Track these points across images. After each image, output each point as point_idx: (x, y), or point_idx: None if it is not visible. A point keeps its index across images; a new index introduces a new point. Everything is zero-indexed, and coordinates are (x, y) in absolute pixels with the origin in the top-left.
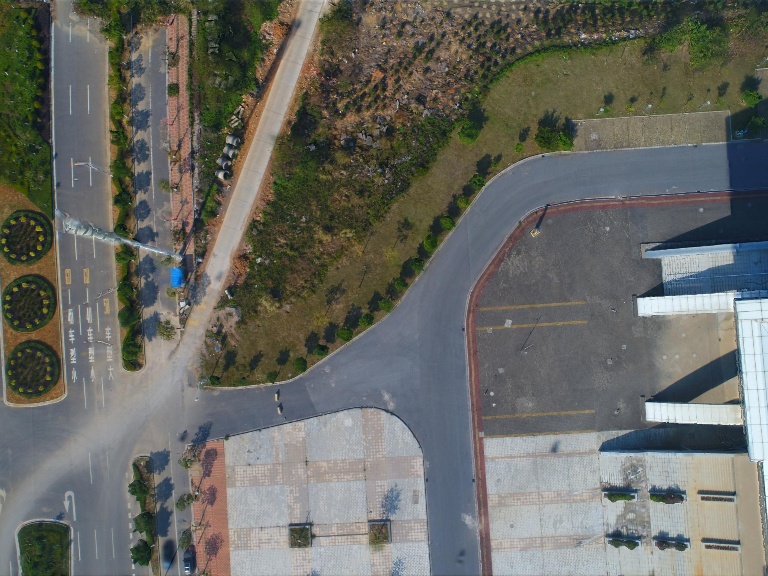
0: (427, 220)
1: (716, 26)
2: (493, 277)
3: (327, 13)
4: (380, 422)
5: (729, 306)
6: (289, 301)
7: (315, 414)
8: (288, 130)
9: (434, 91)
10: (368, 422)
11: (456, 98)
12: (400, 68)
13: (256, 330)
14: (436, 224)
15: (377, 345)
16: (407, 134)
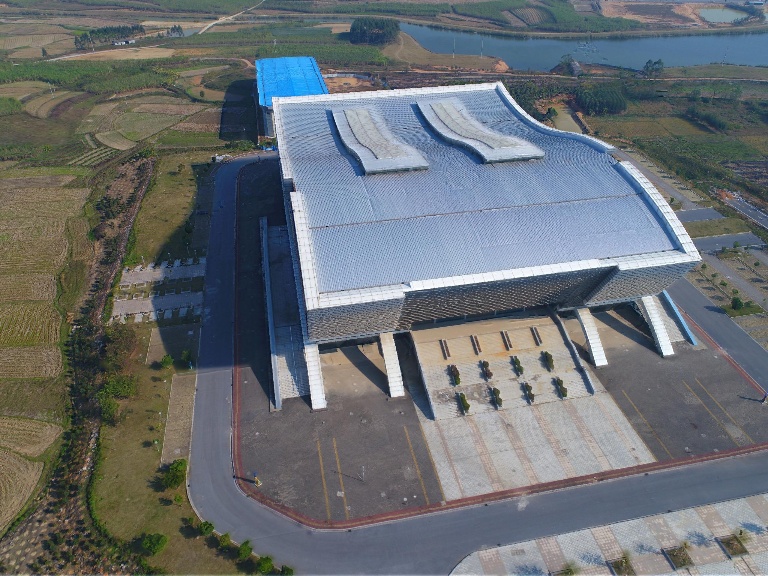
0: None
1: None
2: (299, 511)
3: None
4: None
5: (315, 351)
6: None
7: None
8: None
9: None
10: None
11: (114, 569)
12: None
13: None
14: (245, 569)
15: None
16: None
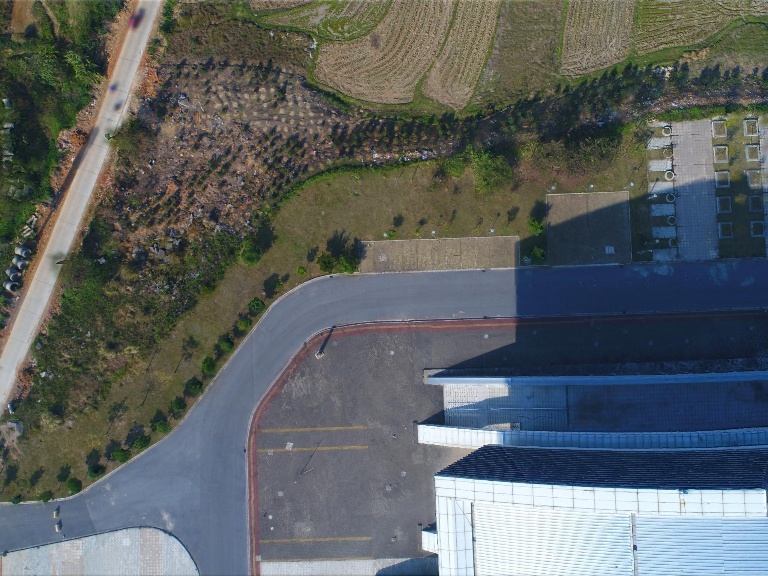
0: (212, 339)
1: (506, 151)
2: (276, 398)
3: (126, 122)
4: (158, 542)
5: None
6: (71, 417)
7: (94, 532)
8: (81, 241)
9: (228, 206)
10: (146, 542)
11: (247, 215)
12: (194, 182)
13: (38, 445)
14: None
15: (158, 464)
16: (198, 249)
